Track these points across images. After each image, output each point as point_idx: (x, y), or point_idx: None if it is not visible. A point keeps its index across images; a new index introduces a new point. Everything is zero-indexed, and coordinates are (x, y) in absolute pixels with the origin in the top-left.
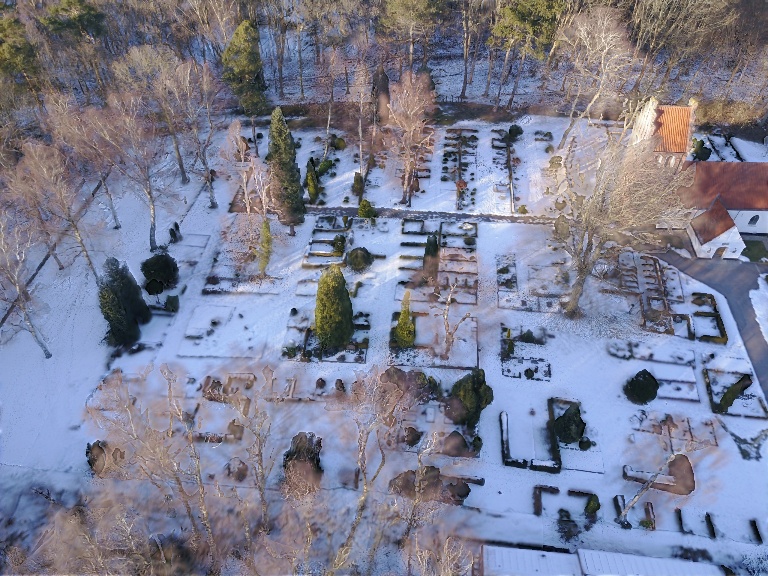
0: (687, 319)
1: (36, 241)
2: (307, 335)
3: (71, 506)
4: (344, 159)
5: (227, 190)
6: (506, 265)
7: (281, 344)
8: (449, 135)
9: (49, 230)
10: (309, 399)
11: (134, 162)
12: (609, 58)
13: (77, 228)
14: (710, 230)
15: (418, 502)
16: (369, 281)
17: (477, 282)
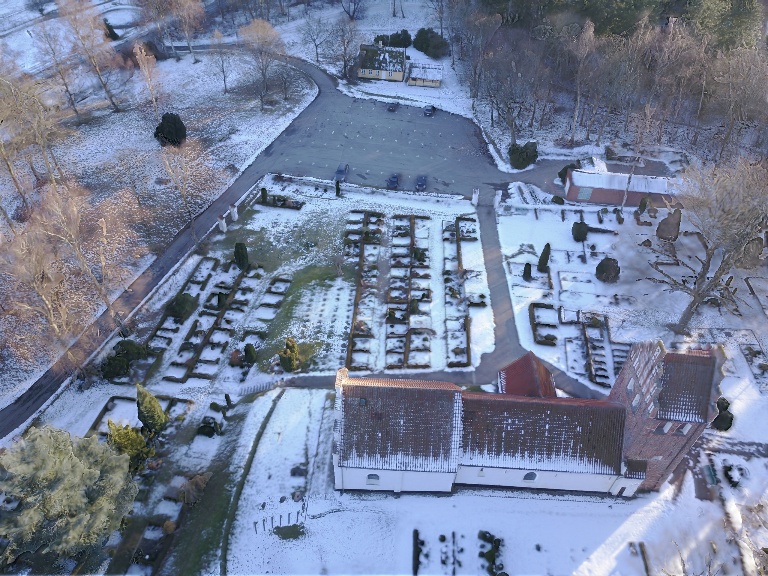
0: None
1: None
2: None
3: None
4: None
5: None
6: (765, 374)
7: None
8: None
9: None
10: None
11: None
12: None
13: None
14: (546, 377)
15: None
16: None
17: None
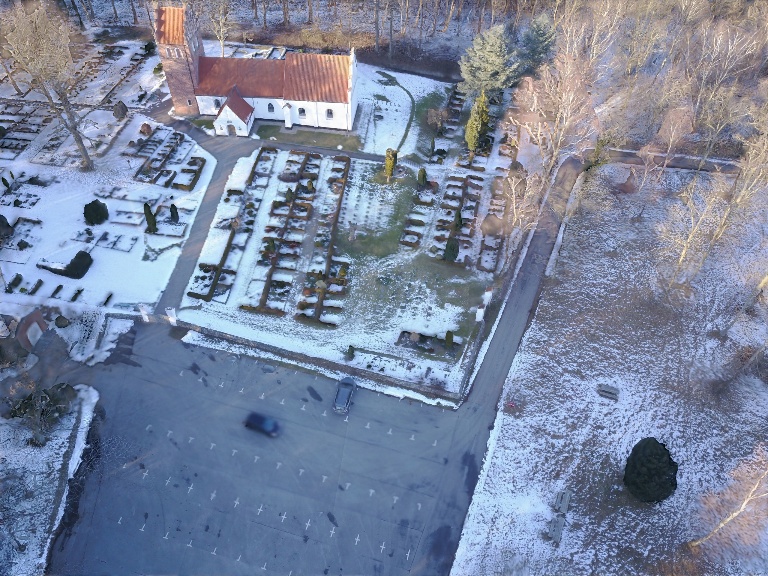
0: None
1: None
2: None
3: None
4: None
5: None
6: (60, 136)
7: None
8: (104, 51)
9: None
10: None
11: None
12: (313, 2)
13: None
14: None
15: None
16: None
17: (26, 145)
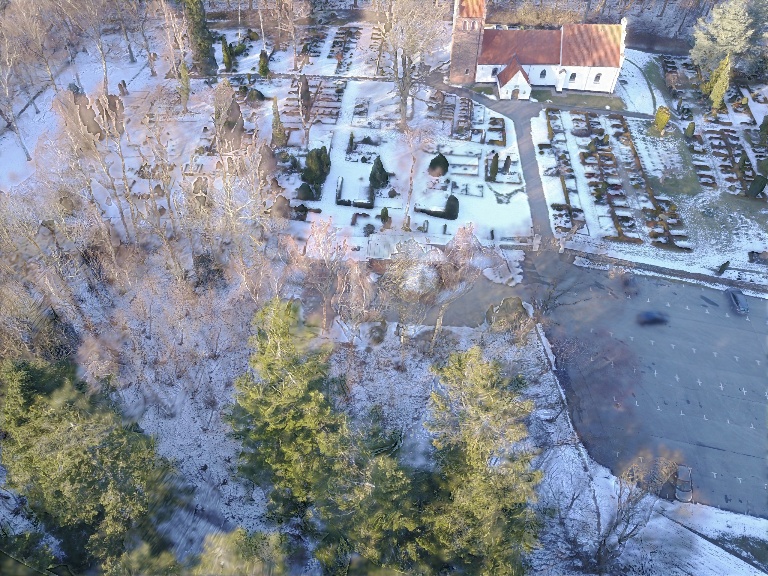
0: (482, 132)
1: (20, 53)
2: (213, 142)
3: (46, 234)
4: (256, 46)
5: (165, 66)
6: (362, 103)
7: (195, 147)
8: (340, 31)
9: (28, 63)
10: (210, 173)
11: (89, 23)
12: None
13: (48, 64)
14: (507, 77)
15: (274, 218)
16: (262, 113)
17: (338, 112)
